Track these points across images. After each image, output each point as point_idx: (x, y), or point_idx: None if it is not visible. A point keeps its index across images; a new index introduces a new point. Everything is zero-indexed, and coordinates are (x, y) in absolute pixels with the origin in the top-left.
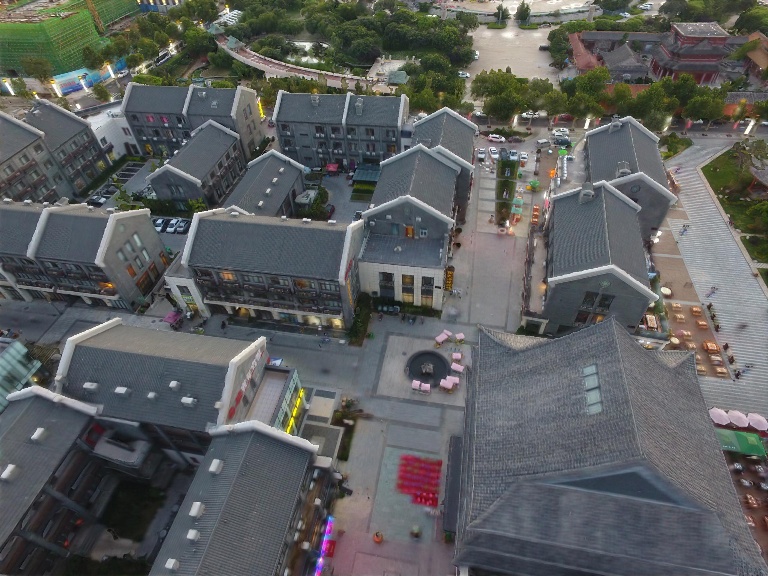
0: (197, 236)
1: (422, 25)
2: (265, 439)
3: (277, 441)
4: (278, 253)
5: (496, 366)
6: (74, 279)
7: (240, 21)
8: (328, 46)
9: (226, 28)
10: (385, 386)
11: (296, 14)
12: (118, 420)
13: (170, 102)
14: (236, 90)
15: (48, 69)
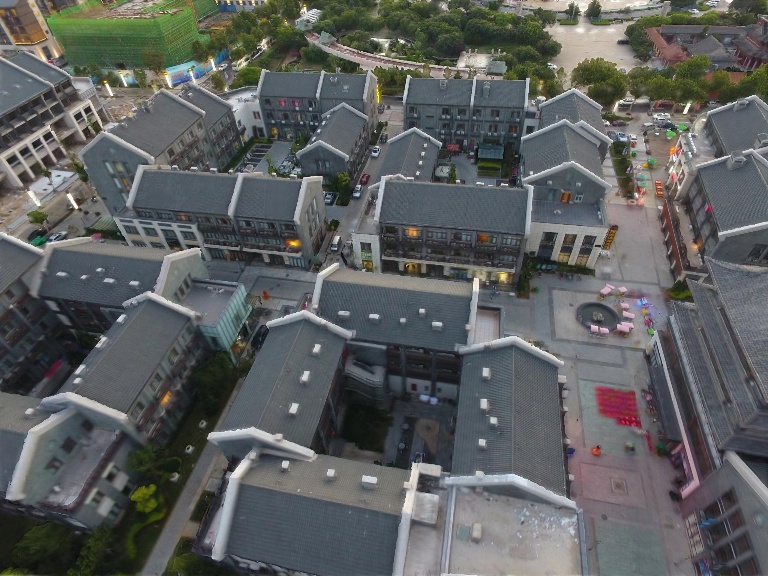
0: (385, 197)
1: (500, 21)
2: (523, 353)
3: (531, 355)
4: (464, 211)
5: (738, 287)
6: (263, 238)
7: (320, 19)
8: (407, 42)
9: (314, 25)
10: (562, 331)
11: (368, 13)
12: (367, 344)
13: (303, 87)
14: (366, 75)
15: (163, 61)
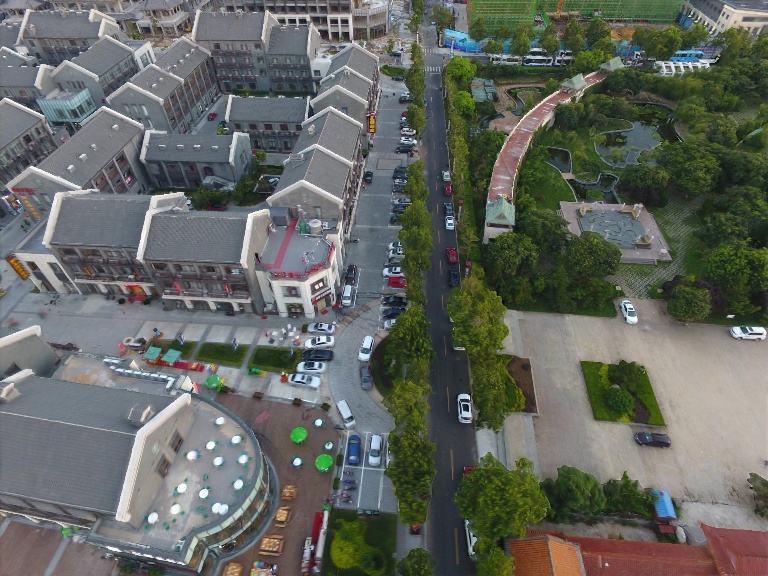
0: None
1: None
2: None
3: None
4: None
5: None
6: None
7: (684, 76)
8: None
9: (619, 68)
10: None
11: None
12: None
13: (334, 70)
14: None
15: None
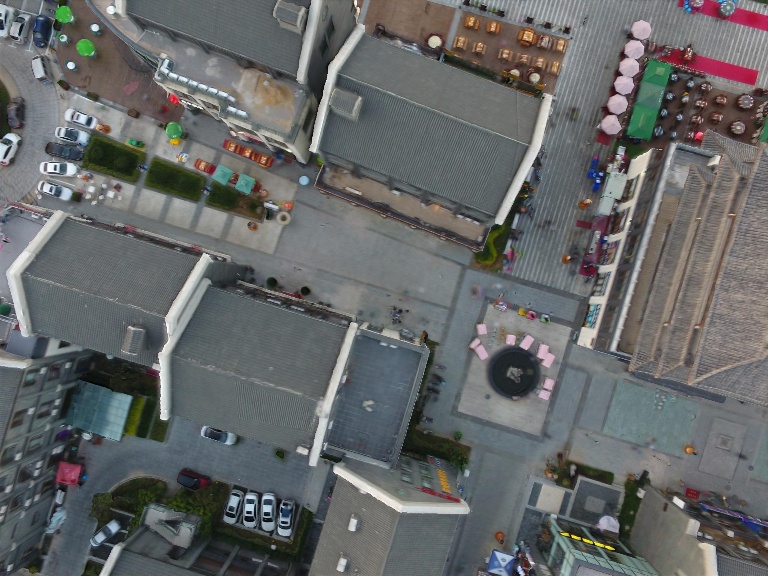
0: None
1: None
2: None
3: None
4: None
5: (758, 381)
6: None
7: None
8: None
9: None
10: (531, 425)
11: None
12: None
13: None
14: None
15: None
